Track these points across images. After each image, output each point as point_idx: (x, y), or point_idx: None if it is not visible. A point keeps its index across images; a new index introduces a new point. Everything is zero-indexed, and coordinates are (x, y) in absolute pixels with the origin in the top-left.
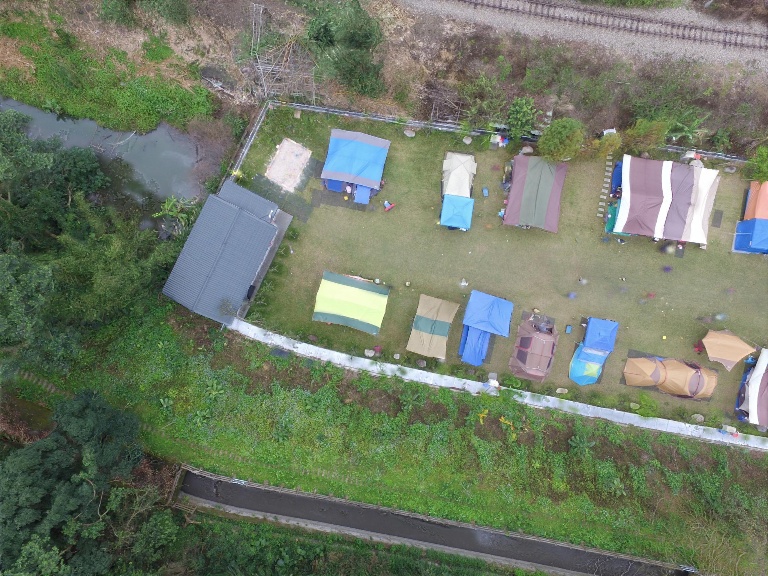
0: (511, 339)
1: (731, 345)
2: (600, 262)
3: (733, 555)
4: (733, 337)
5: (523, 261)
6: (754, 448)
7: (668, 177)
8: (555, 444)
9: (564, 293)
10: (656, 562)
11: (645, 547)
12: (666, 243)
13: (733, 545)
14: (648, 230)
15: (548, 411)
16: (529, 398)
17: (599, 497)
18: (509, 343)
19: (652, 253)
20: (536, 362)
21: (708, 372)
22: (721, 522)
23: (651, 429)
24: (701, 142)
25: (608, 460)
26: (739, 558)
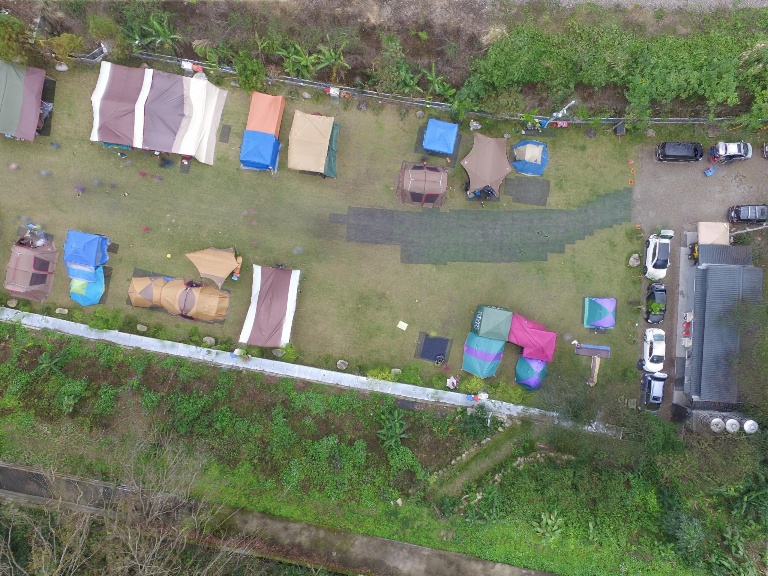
0: (7, 256)
1: (219, 260)
2: (101, 177)
3: (186, 475)
4: (227, 253)
5: (17, 174)
6: (269, 373)
7: (148, 85)
8: (31, 363)
9: (62, 208)
10: (92, 481)
11: (87, 466)
12: (170, 158)
13: (185, 464)
14: (127, 139)
15: (43, 332)
16: (27, 318)
17: (46, 414)
18: (5, 260)
19: (155, 168)
20: (11, 276)
21: (214, 292)
22: (181, 441)
23: (159, 352)
24: (208, 55)
25: (82, 379)
26: (193, 478)
